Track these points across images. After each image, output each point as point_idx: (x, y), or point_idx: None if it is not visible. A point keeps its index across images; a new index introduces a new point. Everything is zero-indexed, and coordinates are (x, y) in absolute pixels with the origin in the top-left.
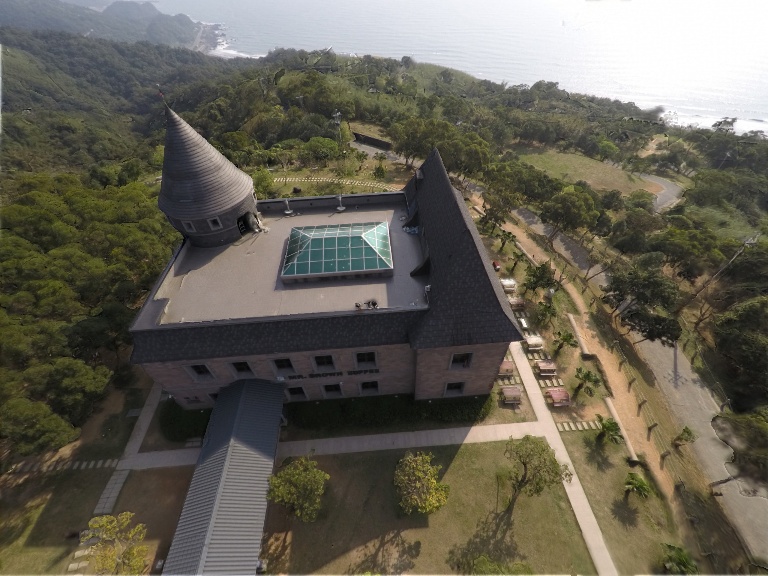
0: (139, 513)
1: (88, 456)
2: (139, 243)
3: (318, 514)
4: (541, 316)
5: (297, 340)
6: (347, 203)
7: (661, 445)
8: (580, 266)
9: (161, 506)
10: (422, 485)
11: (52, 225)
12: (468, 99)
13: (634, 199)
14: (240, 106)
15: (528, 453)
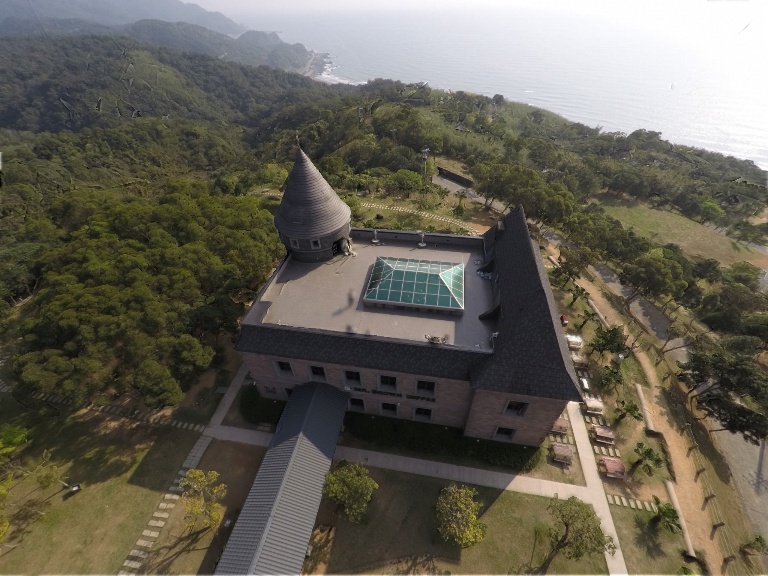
0: None
1: (183, 418)
2: (250, 249)
3: None
4: (605, 380)
5: (370, 358)
6: (428, 240)
7: (726, 548)
8: (658, 335)
9: (233, 475)
10: (462, 517)
11: (188, 224)
12: (557, 142)
13: (735, 272)
14: (337, 130)
15: (572, 514)
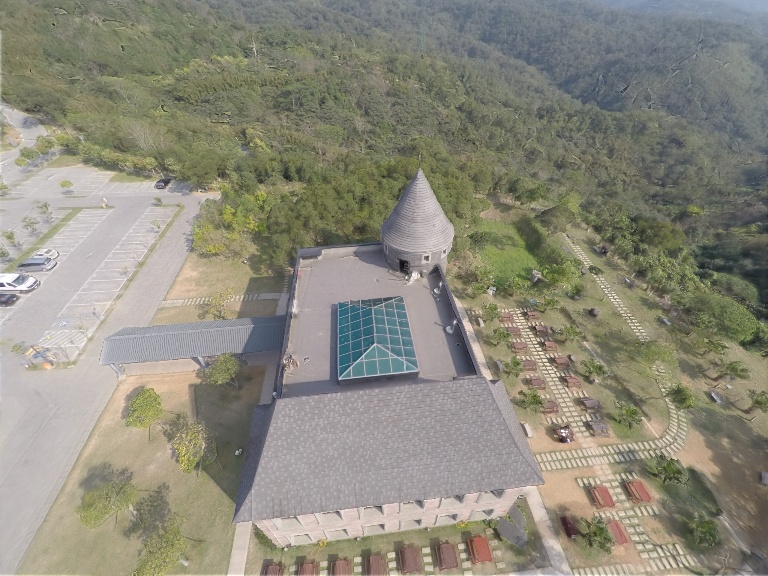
0: (254, 310)
1: None
2: None
3: (224, 395)
4: None
5: None
6: None
7: None
8: None
9: None
10: None
11: None
12: None
13: None
14: None
15: None
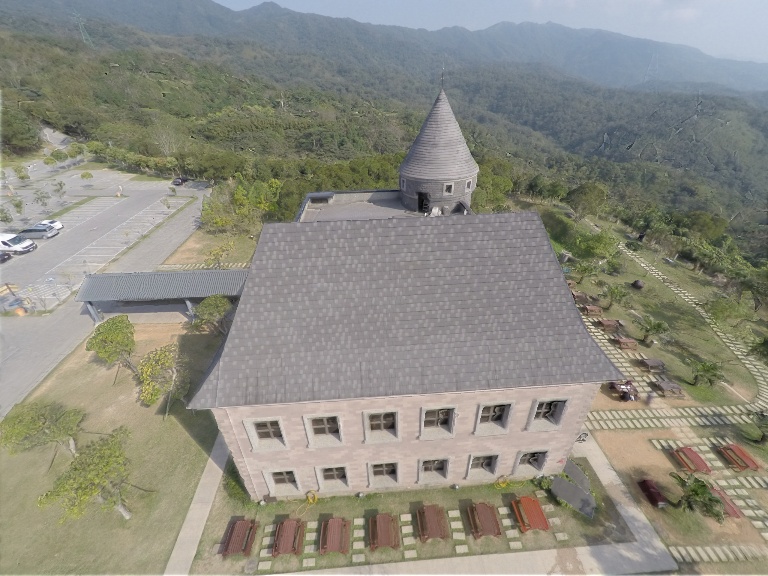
0: None
1: None
2: None
3: (210, 344)
4: None
5: None
6: None
7: None
8: None
9: None
10: None
11: None
12: None
13: None
14: None
15: None
